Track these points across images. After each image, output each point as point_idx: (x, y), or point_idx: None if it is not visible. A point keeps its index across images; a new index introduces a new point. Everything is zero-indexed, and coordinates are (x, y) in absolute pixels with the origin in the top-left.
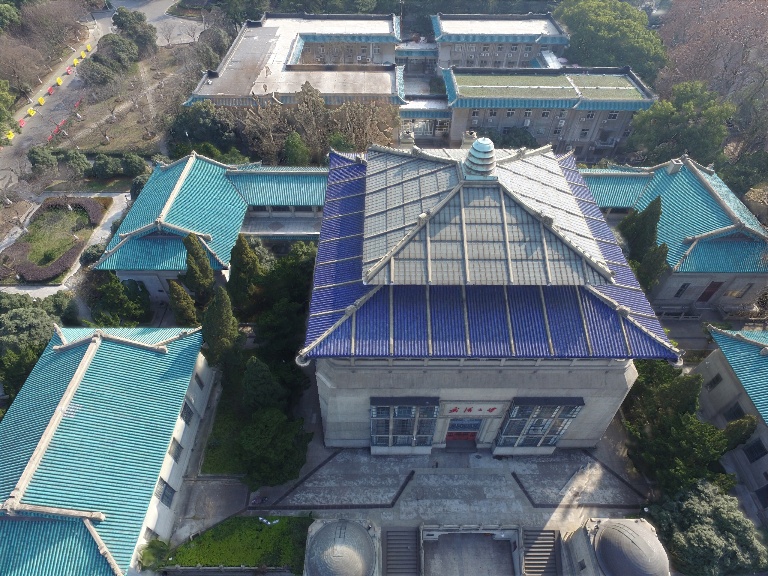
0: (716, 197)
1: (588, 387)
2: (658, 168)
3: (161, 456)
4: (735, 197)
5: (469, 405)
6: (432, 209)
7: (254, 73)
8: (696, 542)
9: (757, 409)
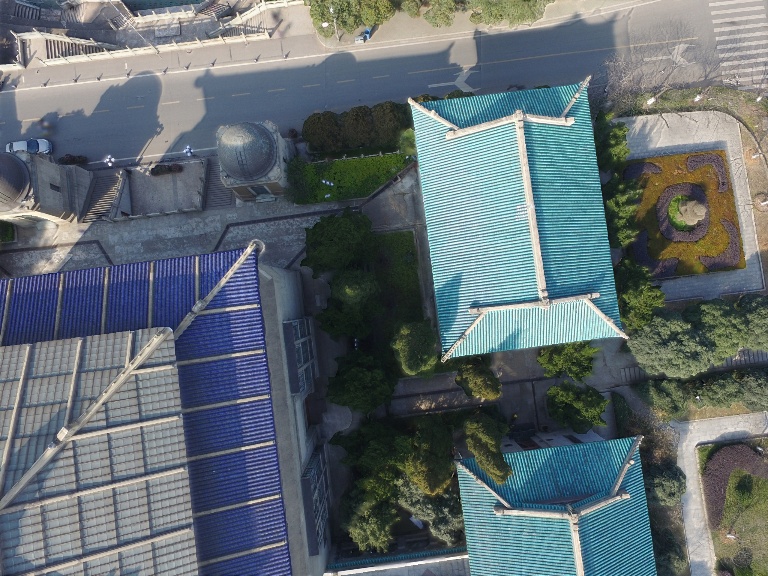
0: None
1: None
2: None
3: (427, 202)
4: None
5: None
6: (48, 452)
7: None
8: None
9: None
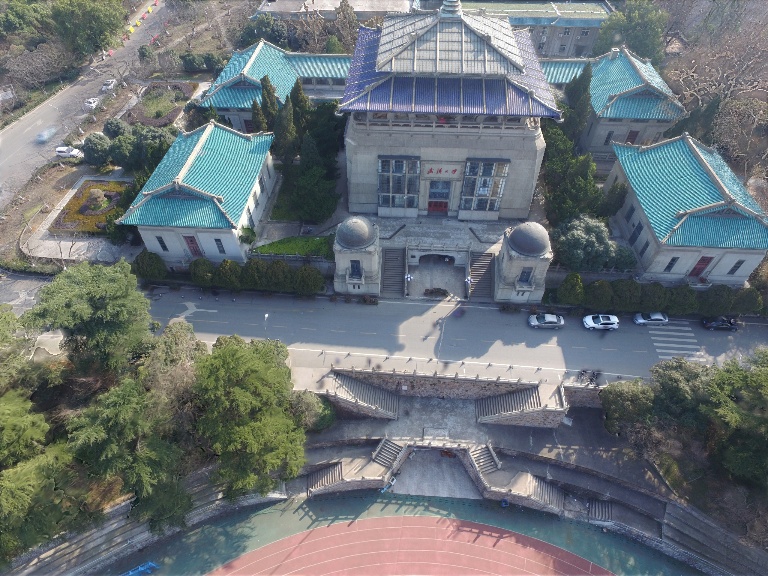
0: (637, 69)
1: (512, 149)
2: (603, 57)
3: (252, 185)
4: (660, 79)
5: (440, 166)
6: (419, 32)
7: None
8: (571, 237)
9: (628, 180)
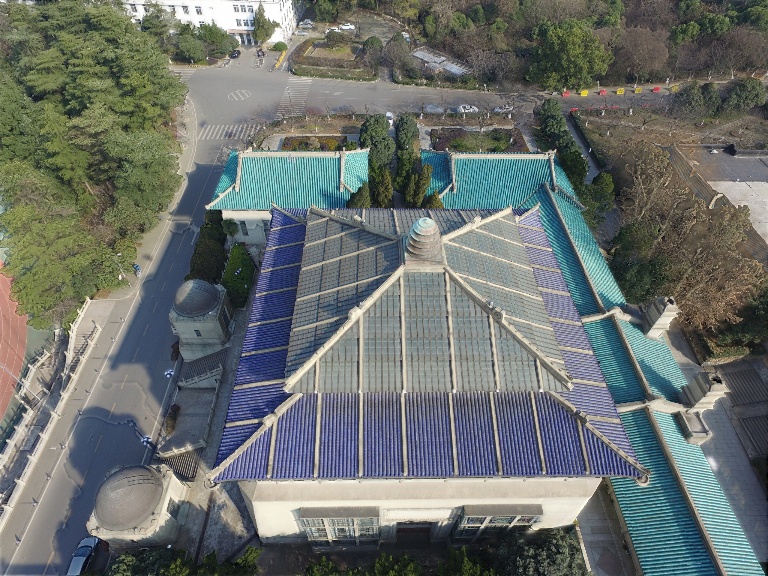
0: None
1: None
2: None
3: None
4: None
5: None
6: (367, 224)
7: (767, 178)
8: (115, 569)
9: None
